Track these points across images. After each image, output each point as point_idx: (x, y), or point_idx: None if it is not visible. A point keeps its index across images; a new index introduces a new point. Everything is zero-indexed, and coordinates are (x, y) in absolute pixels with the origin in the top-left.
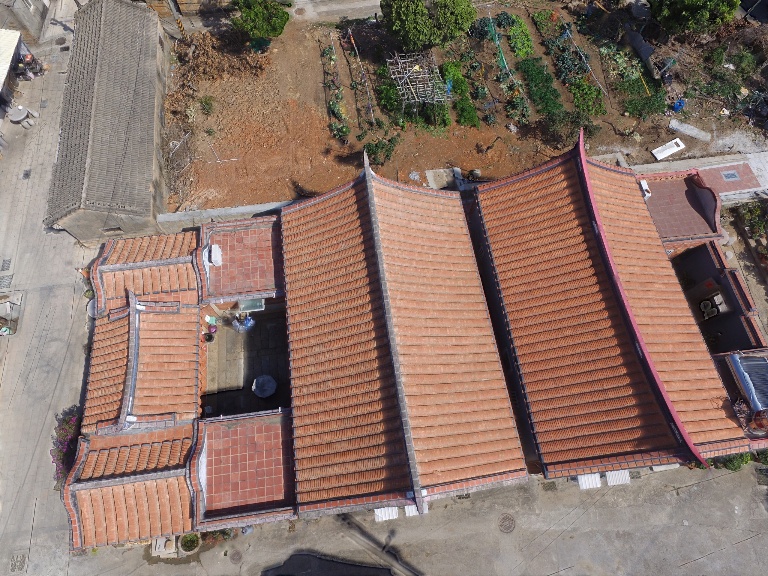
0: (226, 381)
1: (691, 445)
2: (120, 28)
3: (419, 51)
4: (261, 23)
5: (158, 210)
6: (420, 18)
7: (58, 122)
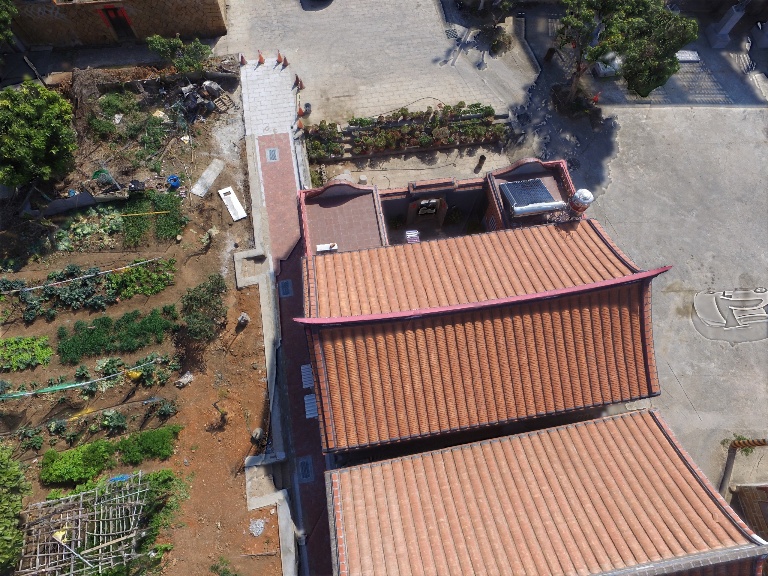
0: None
1: (648, 274)
2: None
3: None
4: None
5: None
6: None
7: None
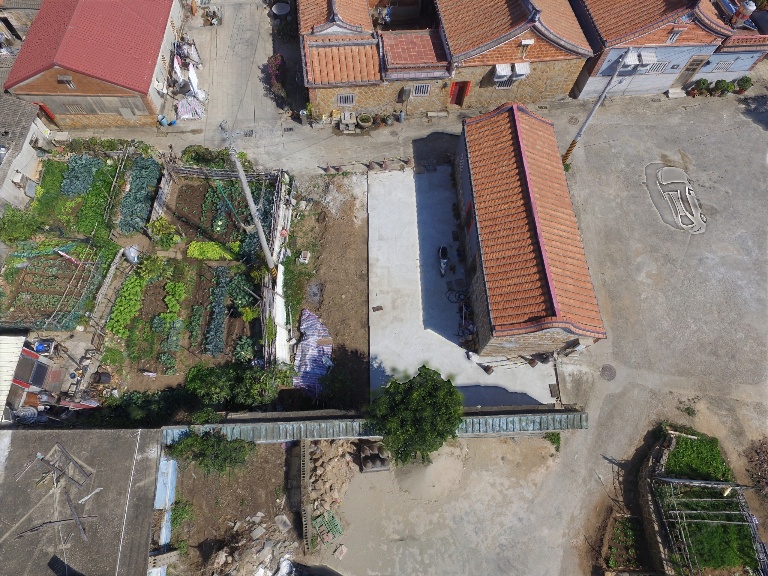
0: None
1: None
2: None
3: None
4: None
5: None
6: None
7: None
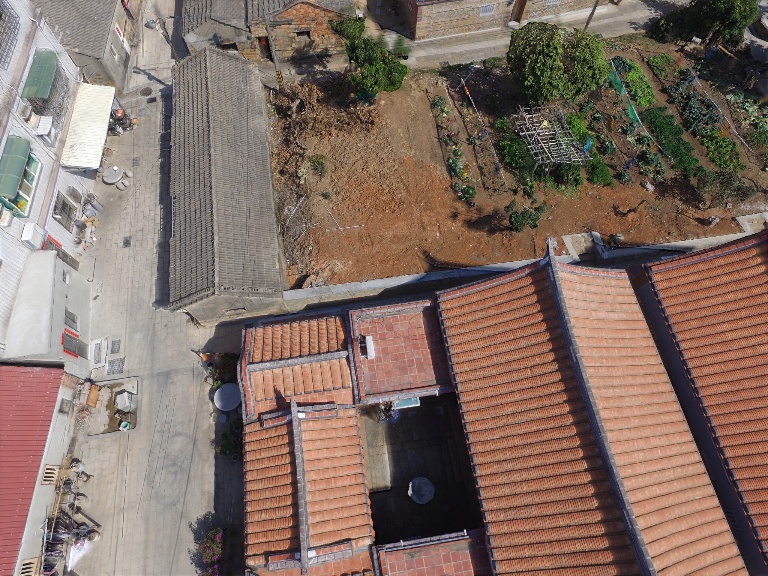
0: (372, 480)
1: None
2: (226, 84)
3: (545, 105)
4: (381, 79)
5: (282, 286)
6: (555, 73)
7: (154, 182)
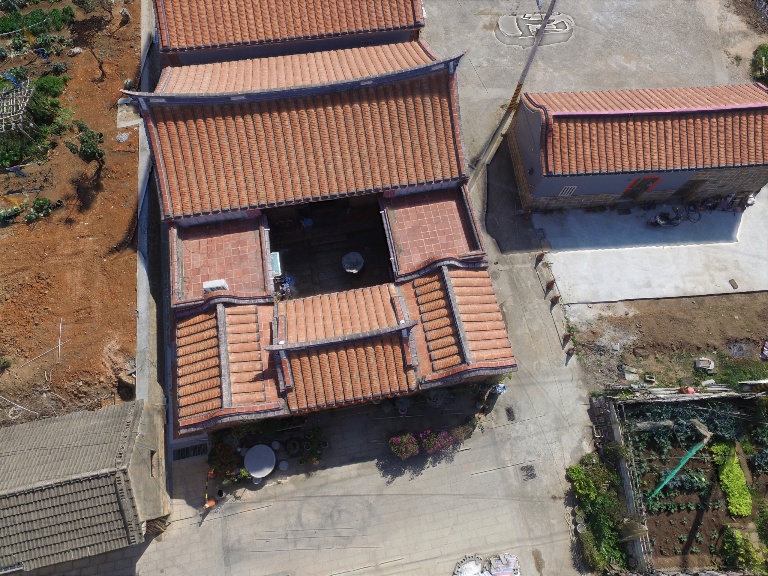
0: None
1: None
2: None
3: None
4: None
5: None
6: None
7: None
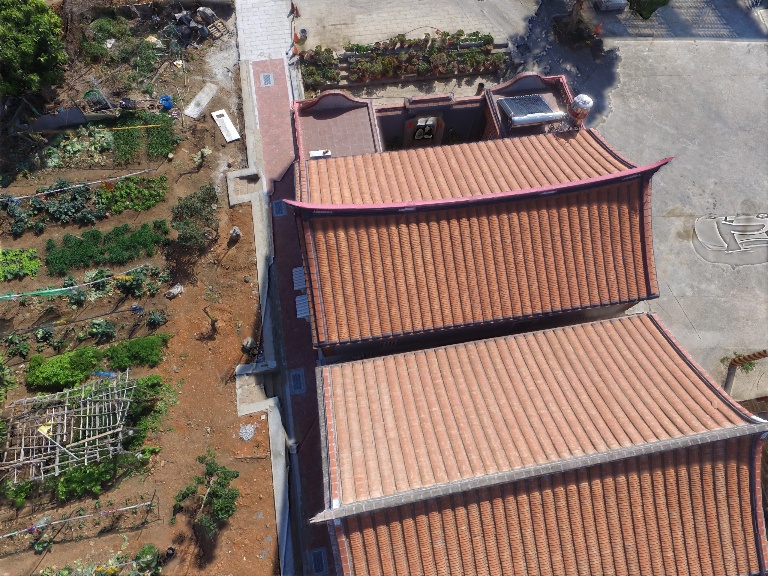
0: None
1: (648, 167)
2: None
3: None
4: None
5: None
6: None
7: None
